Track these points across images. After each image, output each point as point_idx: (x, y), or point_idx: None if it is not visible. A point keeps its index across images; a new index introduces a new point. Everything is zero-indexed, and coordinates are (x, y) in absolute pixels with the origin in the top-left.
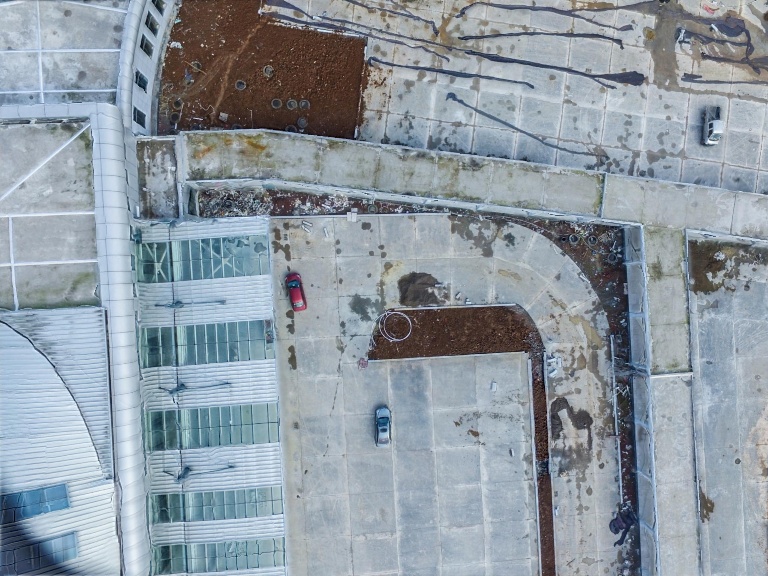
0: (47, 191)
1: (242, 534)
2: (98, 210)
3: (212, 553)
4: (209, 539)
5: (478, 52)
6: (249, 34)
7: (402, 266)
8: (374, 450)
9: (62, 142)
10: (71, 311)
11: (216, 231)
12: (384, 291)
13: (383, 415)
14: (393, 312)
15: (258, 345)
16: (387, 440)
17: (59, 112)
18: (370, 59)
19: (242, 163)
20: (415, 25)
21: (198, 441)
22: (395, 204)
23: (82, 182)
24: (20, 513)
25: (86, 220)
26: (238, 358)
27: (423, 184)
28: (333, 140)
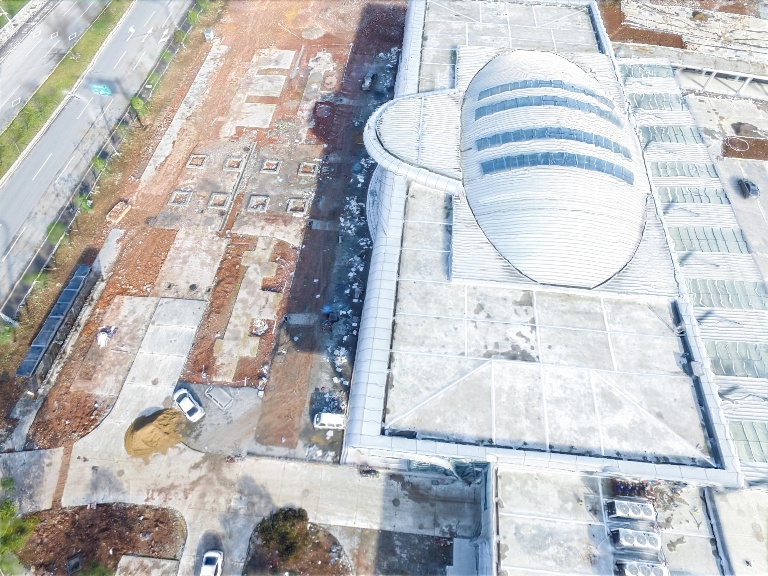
0: (569, 24)
1: (692, 184)
2: (599, 28)
3: (672, 193)
4: (667, 185)
5: (747, 44)
6: (618, 29)
7: (731, 119)
8: (745, 203)
9: (574, 12)
10: (592, 53)
11: (641, 61)
12: (723, 128)
13: (748, 180)
14: (733, 137)
15: (677, 104)
16: (757, 192)
17: (575, 2)
18: (686, 42)
19: (637, 54)
20: (707, 34)
21: (648, 139)
22: (716, 95)
23: (585, 23)
24: (596, 97)
25: (589, 33)
26: (665, 108)
27: (745, 70)
28: (686, 51)
